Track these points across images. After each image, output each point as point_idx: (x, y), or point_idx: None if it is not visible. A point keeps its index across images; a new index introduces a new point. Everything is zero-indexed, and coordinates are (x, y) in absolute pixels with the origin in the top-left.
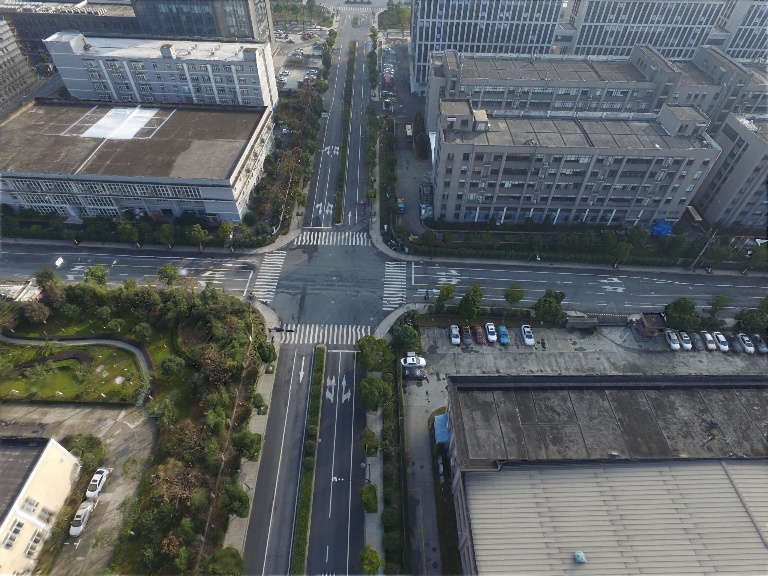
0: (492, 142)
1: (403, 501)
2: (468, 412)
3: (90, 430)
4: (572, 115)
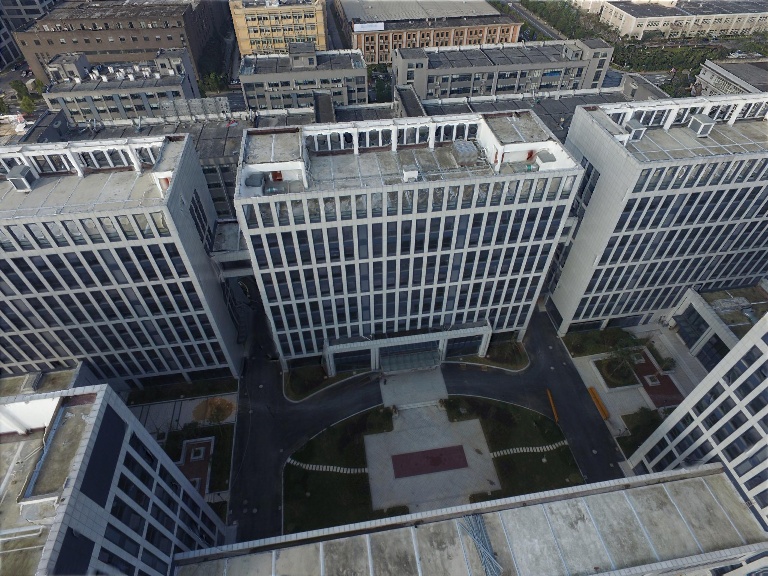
0: (554, 49)
1: (520, 40)
2: (512, 22)
3: (638, 45)
4: (501, 68)
